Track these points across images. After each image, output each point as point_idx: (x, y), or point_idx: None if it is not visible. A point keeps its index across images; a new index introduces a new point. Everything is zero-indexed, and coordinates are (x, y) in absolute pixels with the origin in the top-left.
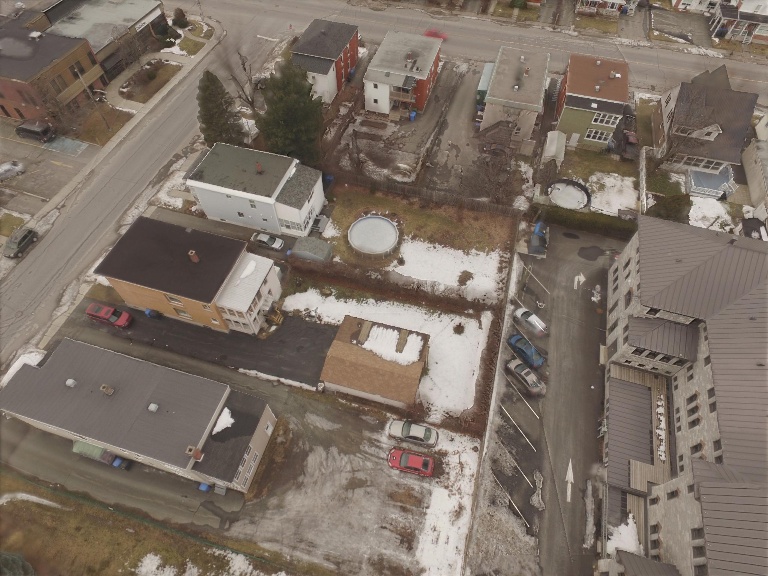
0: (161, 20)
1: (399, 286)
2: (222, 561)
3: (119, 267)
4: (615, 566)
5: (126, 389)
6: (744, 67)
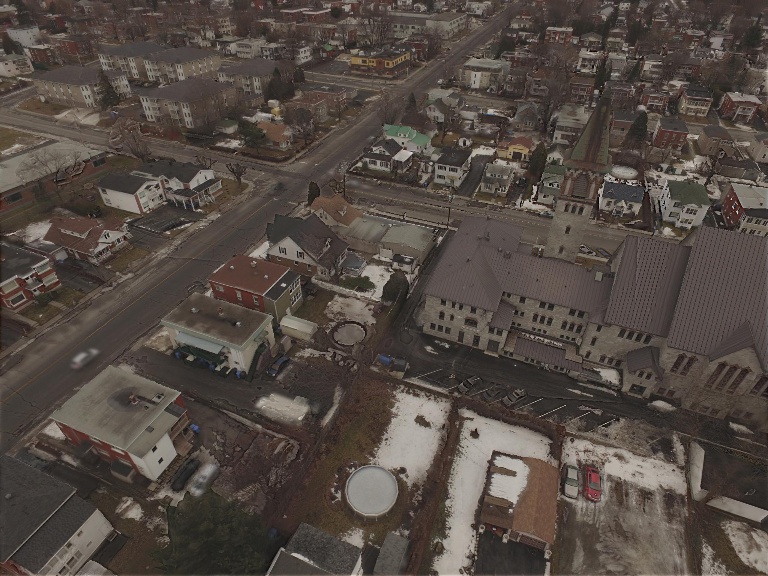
0: None
1: None
2: None
3: None
4: (633, 378)
5: None
6: (237, 211)
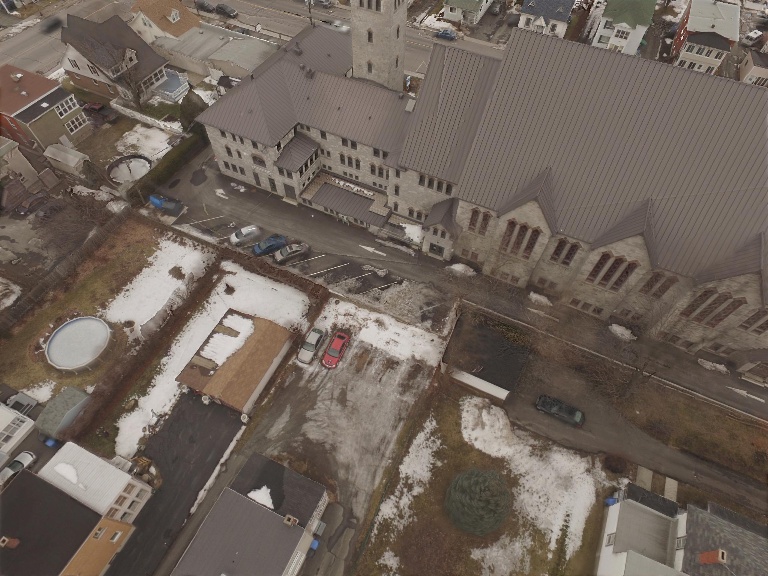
0: None
1: (159, 331)
2: (383, 526)
3: None
4: (429, 235)
5: None
6: (63, 16)
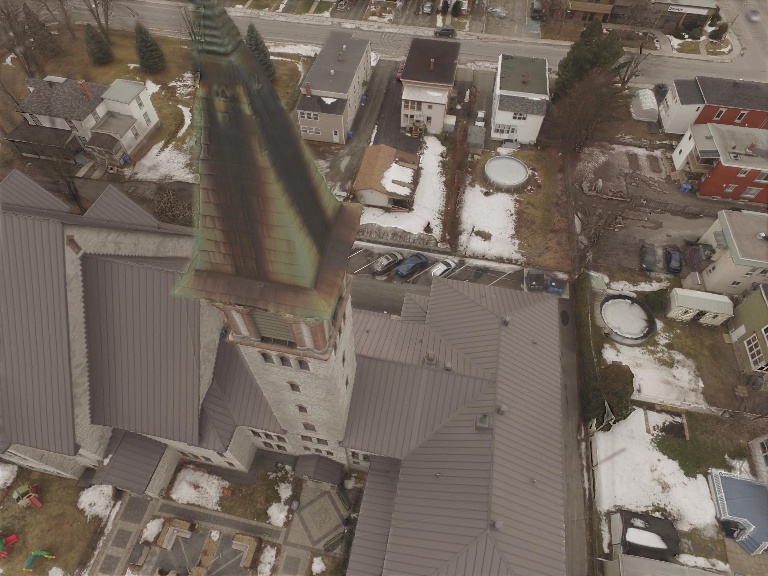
0: (701, 20)
1: None
2: None
3: (419, 45)
4: None
5: (343, 64)
6: None
